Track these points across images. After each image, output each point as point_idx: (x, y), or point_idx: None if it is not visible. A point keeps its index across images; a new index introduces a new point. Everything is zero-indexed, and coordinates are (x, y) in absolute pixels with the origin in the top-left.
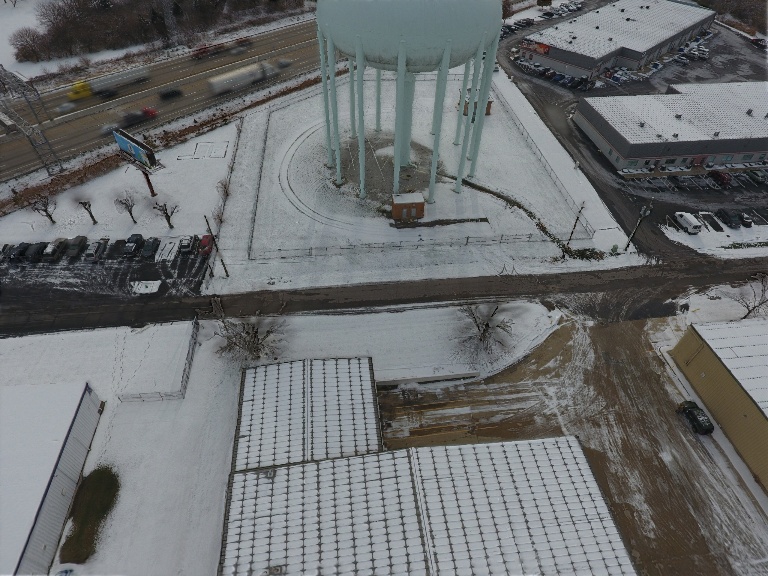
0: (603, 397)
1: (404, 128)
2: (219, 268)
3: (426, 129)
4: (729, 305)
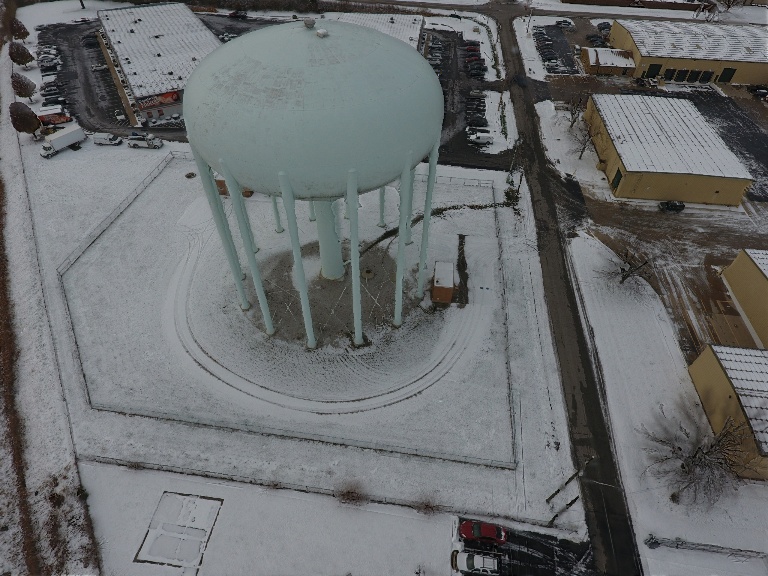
0: (661, 239)
1: (334, 235)
2: (534, 513)
3: (267, 234)
4: (566, 159)
